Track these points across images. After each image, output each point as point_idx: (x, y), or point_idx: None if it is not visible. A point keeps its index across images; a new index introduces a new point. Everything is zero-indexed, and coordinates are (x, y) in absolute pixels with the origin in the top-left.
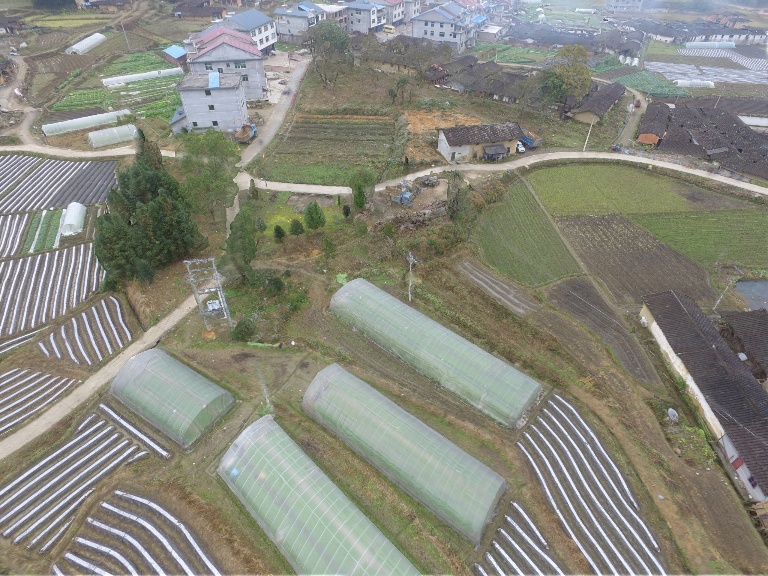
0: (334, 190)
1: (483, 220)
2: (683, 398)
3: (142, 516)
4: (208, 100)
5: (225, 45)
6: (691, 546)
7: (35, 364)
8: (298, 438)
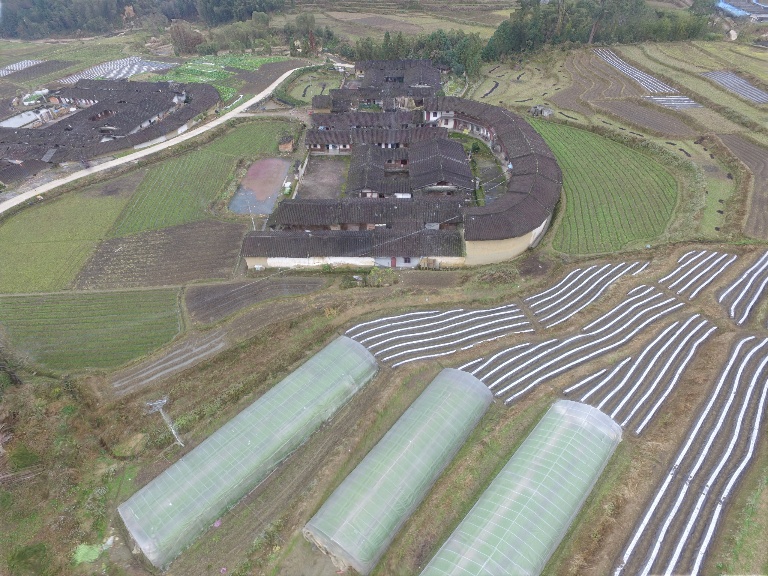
0: None
1: None
2: (338, 272)
3: None
4: None
5: None
6: (456, 297)
7: None
8: (413, 571)
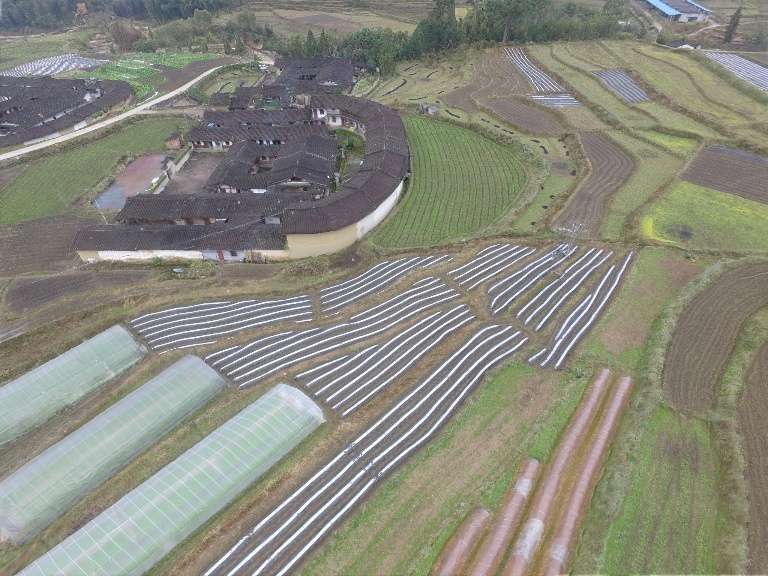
0: None
1: None
2: (168, 265)
3: None
4: None
5: None
6: (258, 288)
7: None
8: None
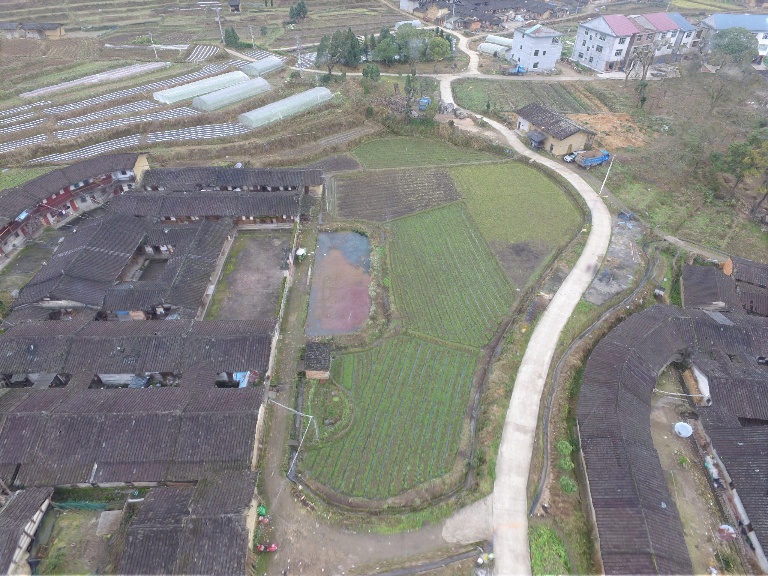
0: (447, 98)
1: (428, 142)
2: None
3: (220, 69)
4: (522, 41)
5: (602, 17)
6: None
7: (289, 59)
8: None
